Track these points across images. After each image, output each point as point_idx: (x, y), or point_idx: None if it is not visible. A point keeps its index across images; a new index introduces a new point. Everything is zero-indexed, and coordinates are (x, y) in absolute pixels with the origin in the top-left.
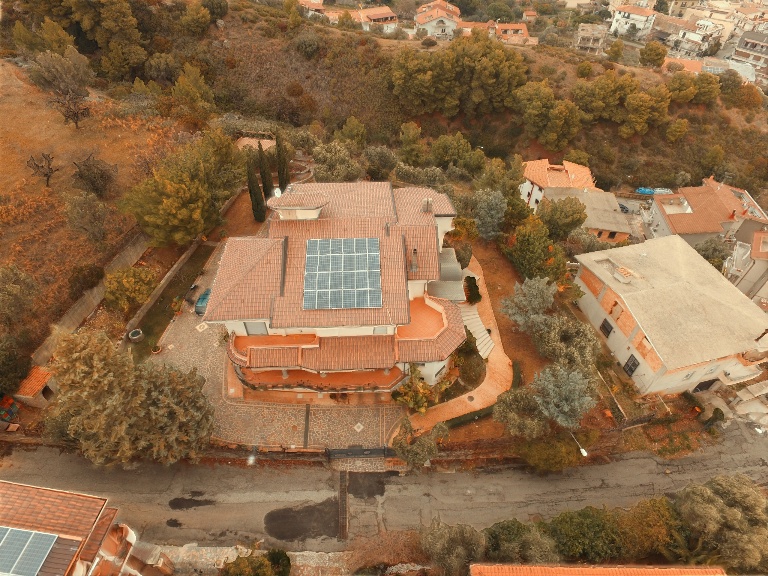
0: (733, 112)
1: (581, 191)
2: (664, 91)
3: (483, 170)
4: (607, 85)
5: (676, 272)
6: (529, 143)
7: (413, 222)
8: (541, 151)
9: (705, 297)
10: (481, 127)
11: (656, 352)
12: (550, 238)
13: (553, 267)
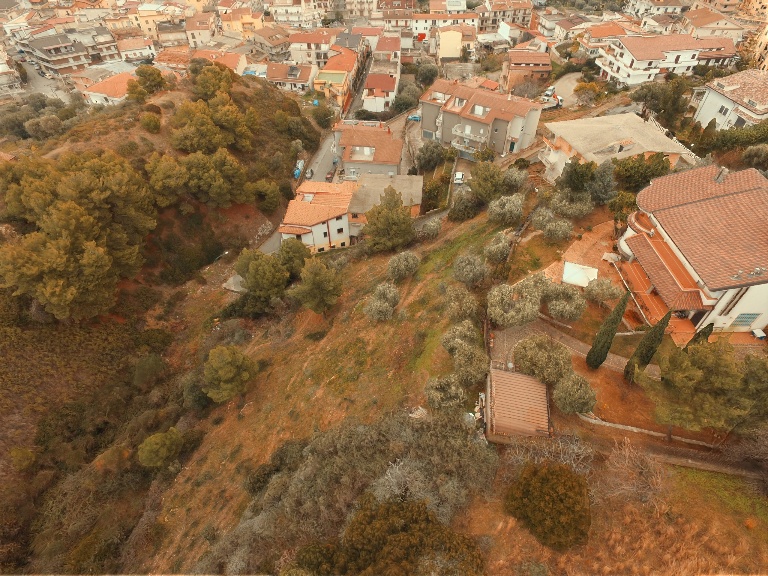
0: (236, 87)
1: (362, 188)
2: (226, 96)
3: (309, 250)
4: (204, 118)
5: (606, 128)
6: (223, 215)
7: (759, 180)
8: (239, 211)
9: None
10: (164, 250)
11: None
12: None
13: (661, 162)
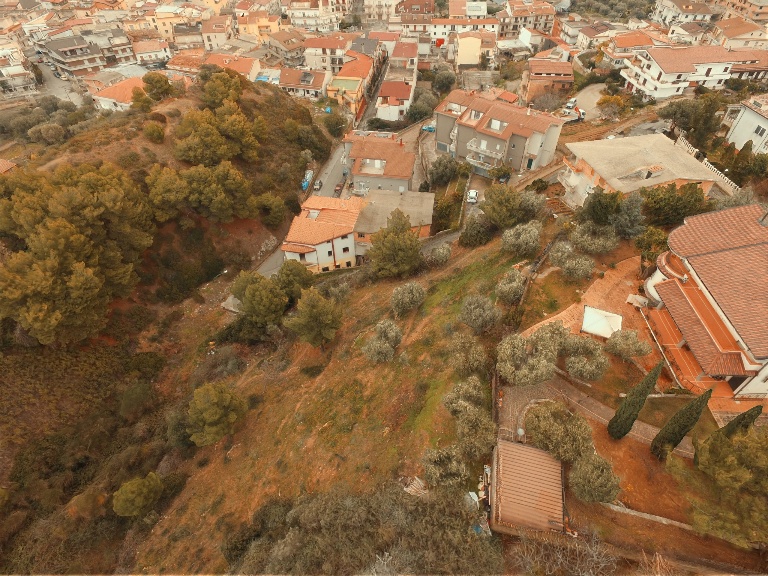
0: (246, 94)
1: (370, 206)
2: (233, 104)
3: (311, 272)
4: (209, 129)
5: (632, 151)
6: (225, 230)
7: None
8: (242, 226)
9: (654, 147)
10: (161, 266)
11: (716, 180)
12: (524, 222)
13: (695, 193)
